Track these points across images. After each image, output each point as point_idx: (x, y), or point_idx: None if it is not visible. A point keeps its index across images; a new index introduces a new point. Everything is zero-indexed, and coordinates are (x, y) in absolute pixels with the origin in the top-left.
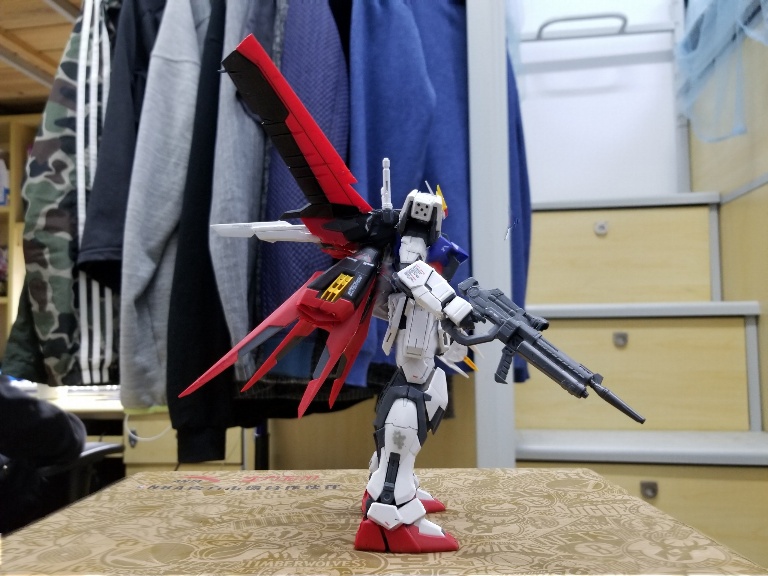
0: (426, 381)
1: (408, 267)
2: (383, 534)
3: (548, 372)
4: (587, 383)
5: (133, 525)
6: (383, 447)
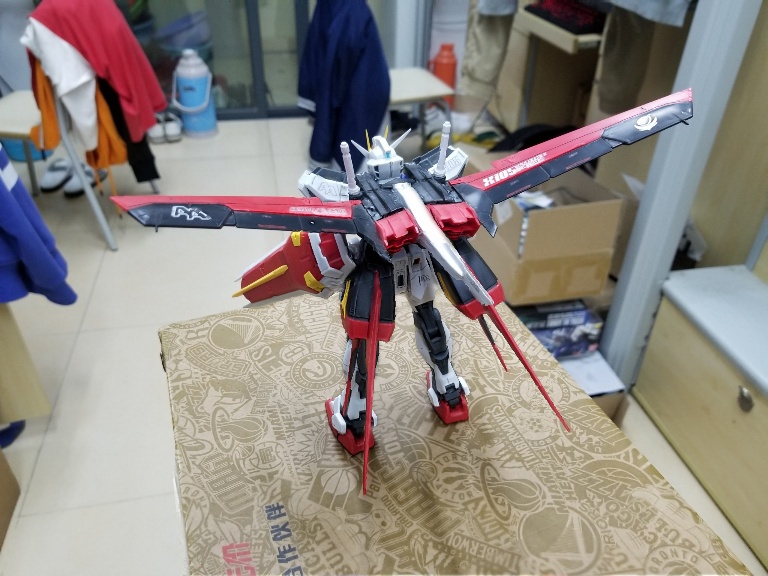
0: None
1: None
2: None
3: None
4: None
5: None
6: None
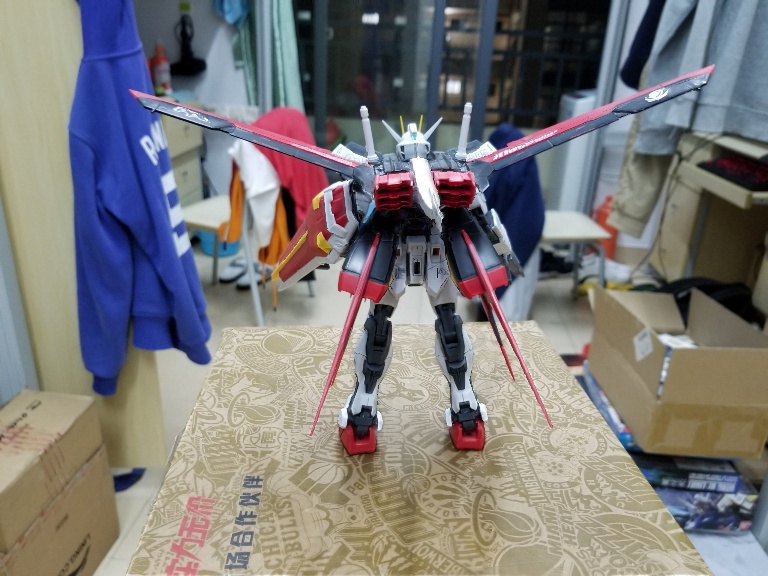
0: None
1: None
2: None
3: None
4: None
5: None
6: None
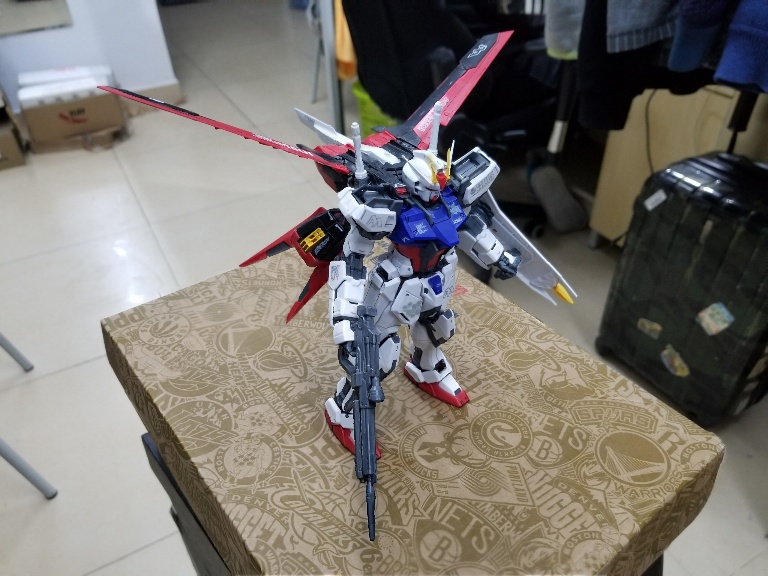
0: None
1: (335, 263)
2: None
3: None
4: None
5: (283, 295)
6: None
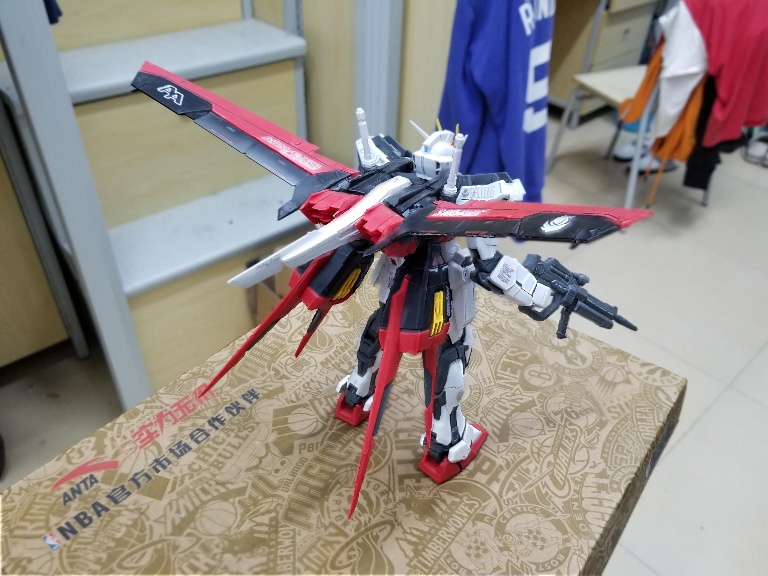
0: (462, 334)
1: (499, 269)
2: (458, 463)
3: (594, 320)
4: None
5: None
6: (444, 405)
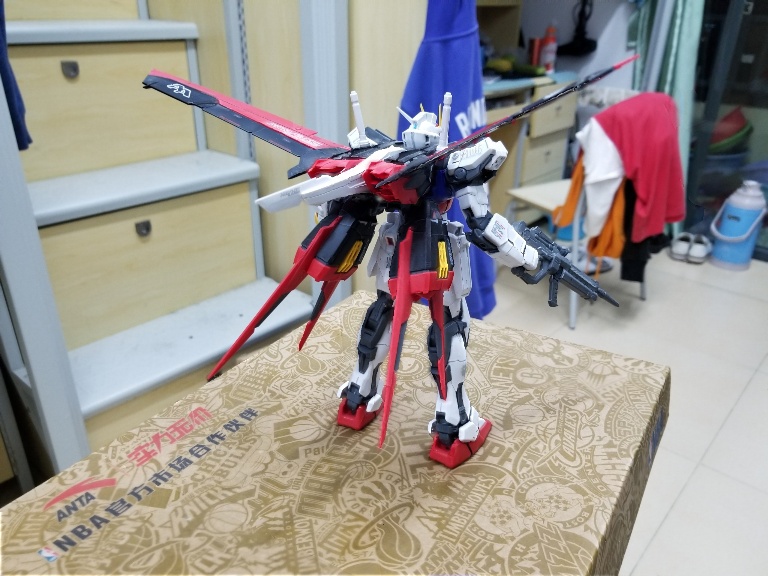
0: (460, 311)
1: (492, 224)
2: (468, 446)
3: (580, 290)
4: (595, 290)
5: None
6: (450, 381)
